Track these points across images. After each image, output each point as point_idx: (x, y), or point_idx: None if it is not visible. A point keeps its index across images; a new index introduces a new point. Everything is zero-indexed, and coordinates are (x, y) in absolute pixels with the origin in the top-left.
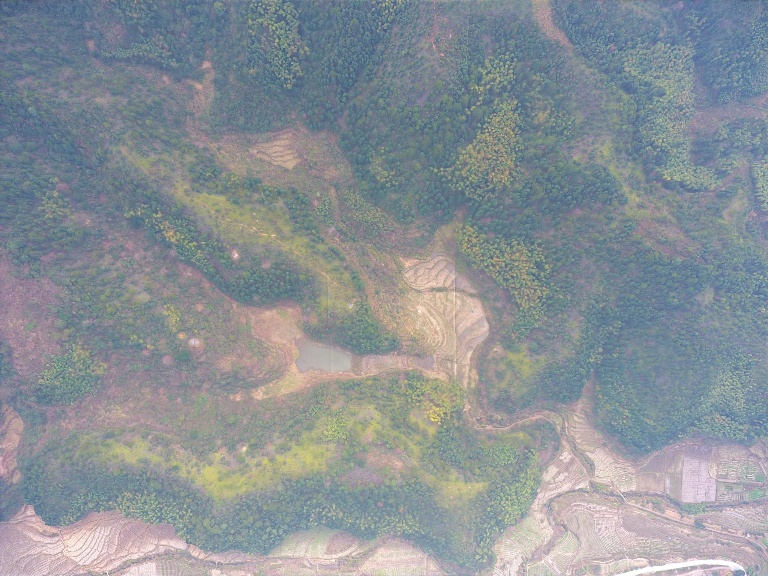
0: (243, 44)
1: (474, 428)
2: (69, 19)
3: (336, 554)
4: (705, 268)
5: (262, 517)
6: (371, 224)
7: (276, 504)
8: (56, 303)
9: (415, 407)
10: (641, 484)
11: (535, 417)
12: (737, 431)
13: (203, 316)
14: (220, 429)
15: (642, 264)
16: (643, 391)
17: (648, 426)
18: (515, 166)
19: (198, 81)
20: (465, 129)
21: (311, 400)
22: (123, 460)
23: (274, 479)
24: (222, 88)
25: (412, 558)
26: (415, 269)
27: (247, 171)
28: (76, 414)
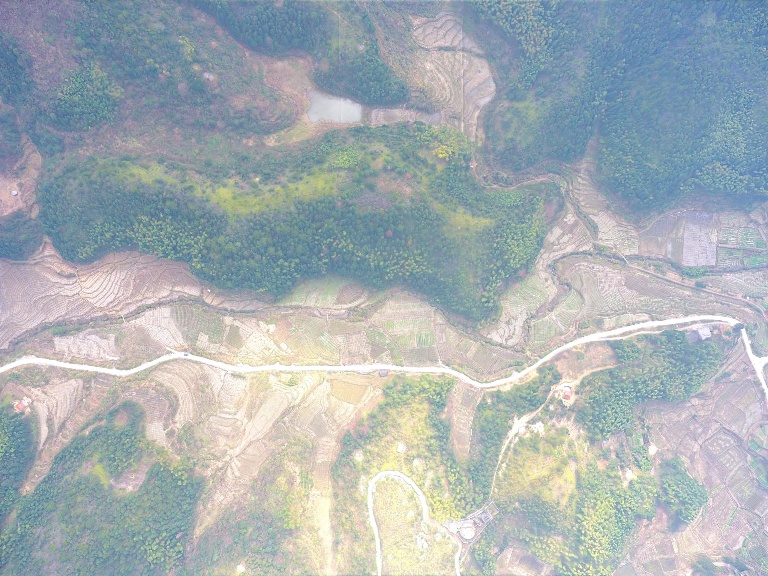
0: None
1: (481, 184)
2: None
3: (346, 305)
4: None
5: (275, 245)
6: None
7: (288, 227)
8: (75, 18)
9: (424, 149)
10: (643, 248)
11: (540, 179)
12: (737, 182)
13: (217, 53)
14: (234, 161)
15: None
16: (646, 132)
17: (651, 170)
18: None
19: None
20: None
21: (322, 142)
22: (140, 179)
23: (287, 202)
24: None
25: (420, 311)
26: (423, 28)
27: None
28: (94, 140)
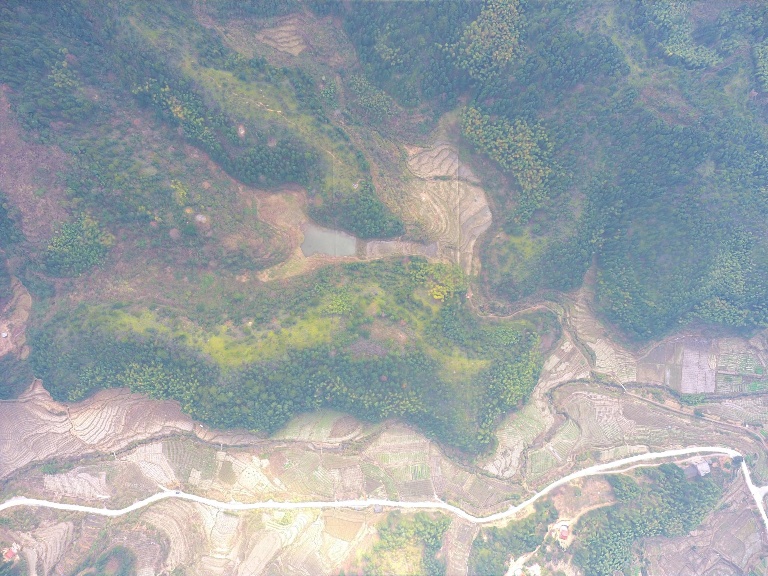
0: None
1: (477, 315)
2: None
3: (340, 438)
4: (706, 135)
5: (267, 390)
6: (376, 109)
7: (281, 375)
8: (65, 170)
9: (419, 287)
10: (641, 375)
11: (537, 307)
12: (737, 316)
13: (210, 194)
14: (226, 304)
15: (644, 134)
16: (644, 271)
17: (649, 308)
18: (519, 44)
19: None
20: (469, 3)
21: (316, 280)
22: (131, 329)
23: (280, 350)
24: None
25: (415, 443)
26: (419, 157)
27: (253, 54)
28: (84, 286)
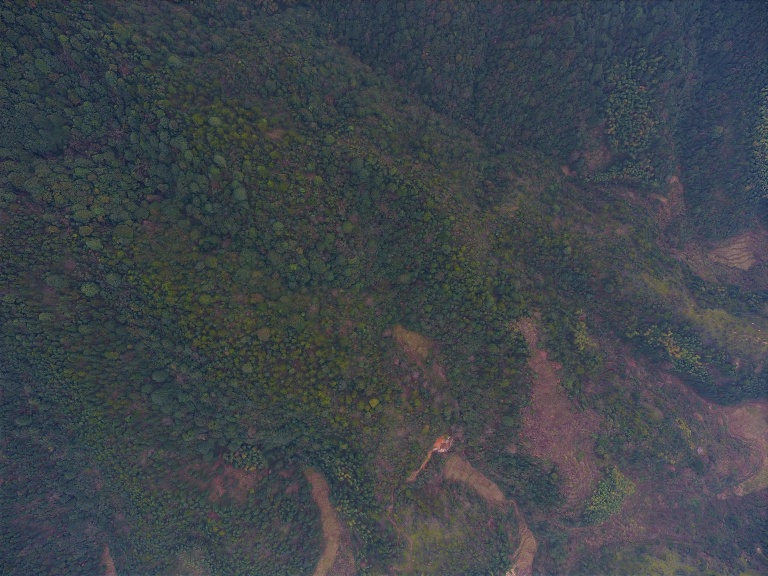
0: (745, 164)
1: None
2: (551, 149)
3: None
4: None
5: None
6: None
7: None
8: (600, 431)
9: None
10: None
11: None
12: None
13: (700, 424)
14: (732, 532)
15: None
16: None
17: None
18: None
19: (663, 195)
20: None
21: None
22: (662, 574)
23: None
24: (702, 203)
25: None
26: None
27: (717, 278)
28: (603, 532)
